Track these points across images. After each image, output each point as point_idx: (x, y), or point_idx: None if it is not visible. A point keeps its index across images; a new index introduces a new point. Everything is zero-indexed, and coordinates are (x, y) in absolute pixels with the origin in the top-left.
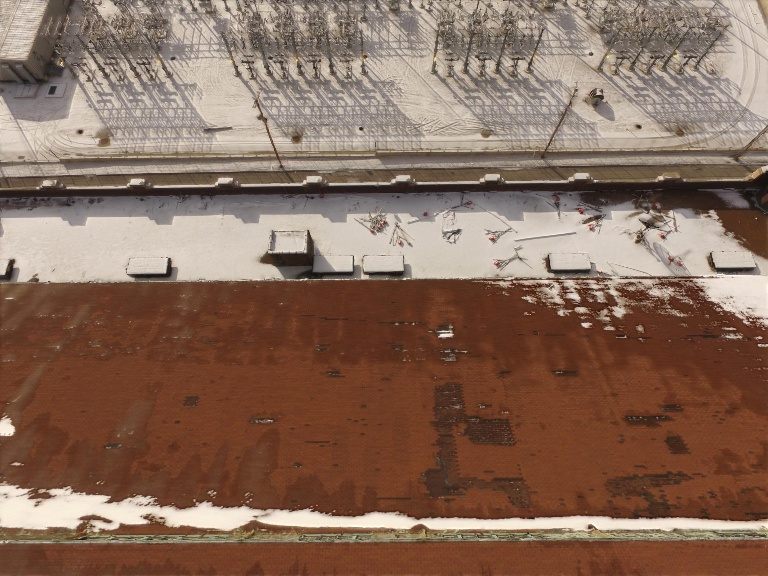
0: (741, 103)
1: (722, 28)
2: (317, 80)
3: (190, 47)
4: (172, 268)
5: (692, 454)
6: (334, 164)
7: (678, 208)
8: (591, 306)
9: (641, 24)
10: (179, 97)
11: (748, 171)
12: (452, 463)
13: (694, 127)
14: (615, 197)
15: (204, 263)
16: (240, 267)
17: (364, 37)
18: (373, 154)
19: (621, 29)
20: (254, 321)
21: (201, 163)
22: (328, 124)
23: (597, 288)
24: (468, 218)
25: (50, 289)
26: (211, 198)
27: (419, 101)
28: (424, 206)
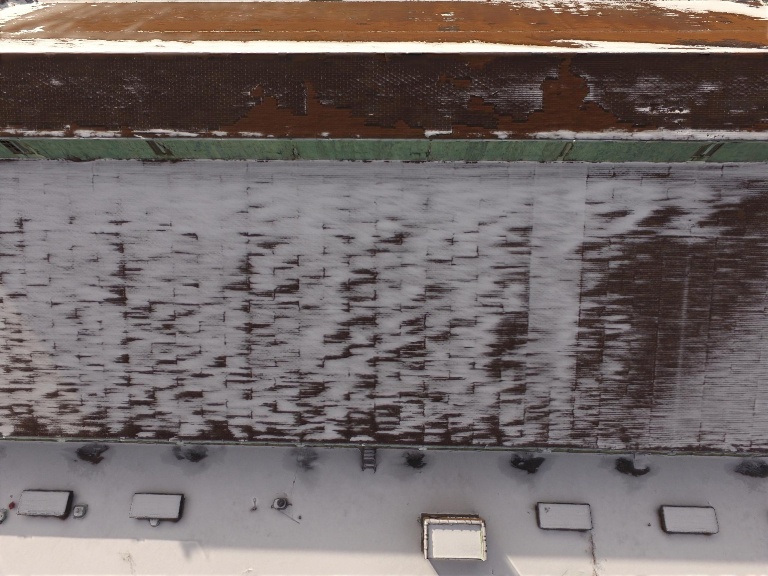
0: None
1: None
2: None
3: None
4: None
5: None
6: None
7: None
8: (563, 7)
9: None
10: None
11: None
12: None
13: None
14: None
15: None
16: None
17: None
18: None
19: None
20: (300, 11)
21: None
22: None
23: (569, 3)
24: None
25: (138, 3)
26: None
27: None
28: None
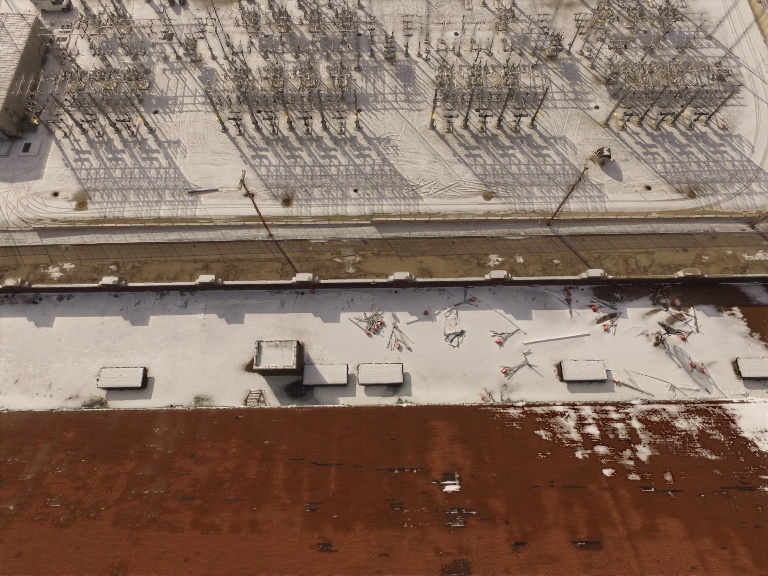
0: (755, 162)
1: (733, 79)
2: (309, 136)
3: (174, 99)
4: (148, 378)
5: None
6: (327, 232)
7: (699, 305)
8: (612, 444)
9: (651, 83)
10: (162, 155)
11: (765, 240)
12: None
13: (706, 188)
14: (631, 292)
15: (183, 372)
16: (223, 377)
17: (358, 89)
18: (368, 221)
19: (628, 80)
20: (236, 468)
21: (185, 231)
22: (320, 185)
23: (617, 418)
24: (472, 317)
25: (8, 421)
26: (192, 294)
27: (417, 160)
28: (424, 303)
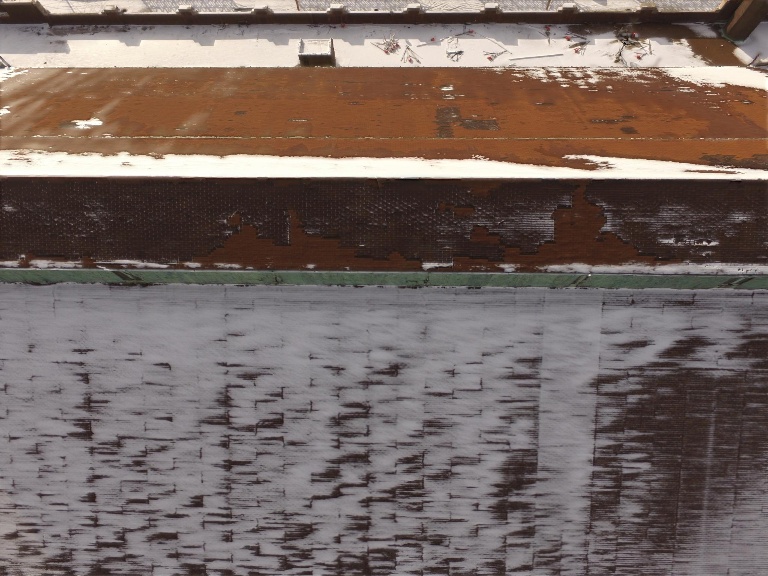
0: None
1: None
2: None
3: None
4: None
5: (640, 134)
6: None
7: (654, 37)
8: (570, 78)
9: None
10: None
11: None
12: (449, 136)
13: None
14: (599, 28)
15: None
16: None
17: None
18: None
19: None
20: (288, 83)
21: None
22: (346, 6)
23: (576, 71)
24: (469, 43)
25: (117, 69)
26: (247, 26)
27: None
28: (431, 34)
